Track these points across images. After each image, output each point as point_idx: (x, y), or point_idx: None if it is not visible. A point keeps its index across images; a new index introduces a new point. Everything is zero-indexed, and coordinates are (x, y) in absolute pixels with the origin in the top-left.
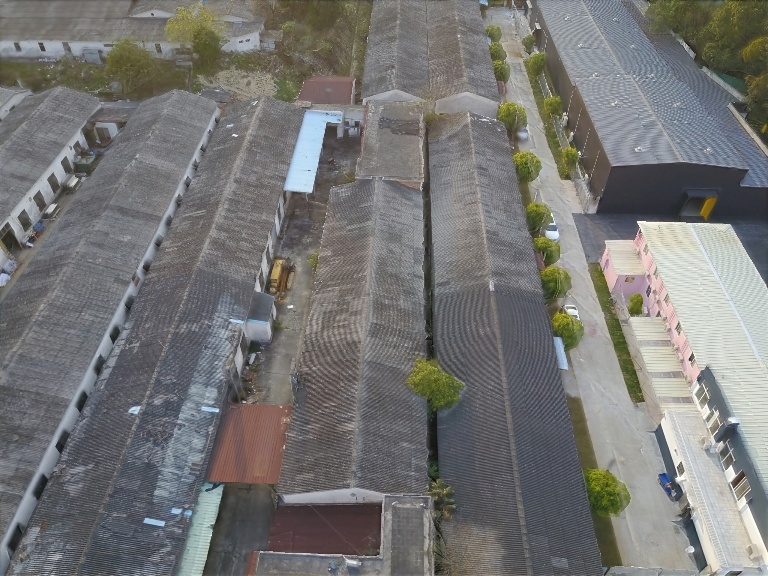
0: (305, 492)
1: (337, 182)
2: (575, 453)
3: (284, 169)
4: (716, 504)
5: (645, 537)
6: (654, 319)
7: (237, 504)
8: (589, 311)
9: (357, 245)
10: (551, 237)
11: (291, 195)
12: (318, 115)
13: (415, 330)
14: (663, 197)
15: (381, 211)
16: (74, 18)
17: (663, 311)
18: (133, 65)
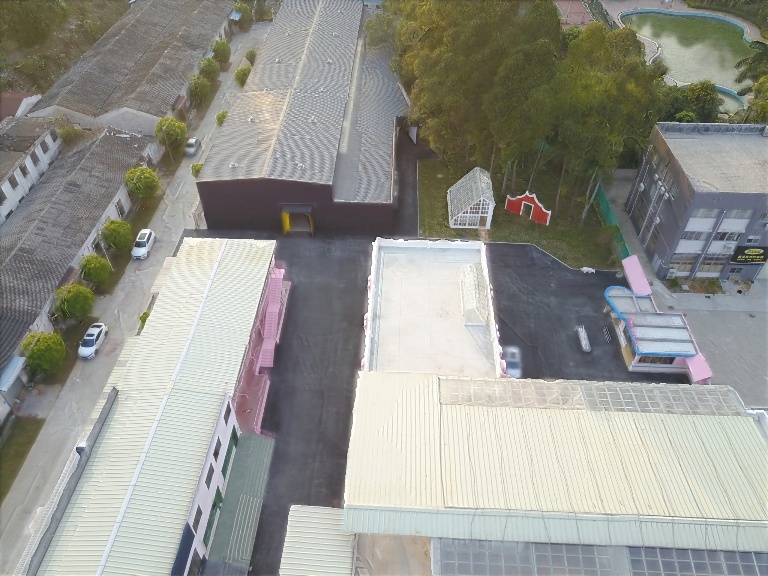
0: None
1: None
2: None
3: None
4: None
5: (1, 565)
6: None
7: None
8: (124, 329)
9: None
10: (136, 254)
11: None
12: None
13: None
14: (265, 212)
15: None
16: None
17: None
18: None
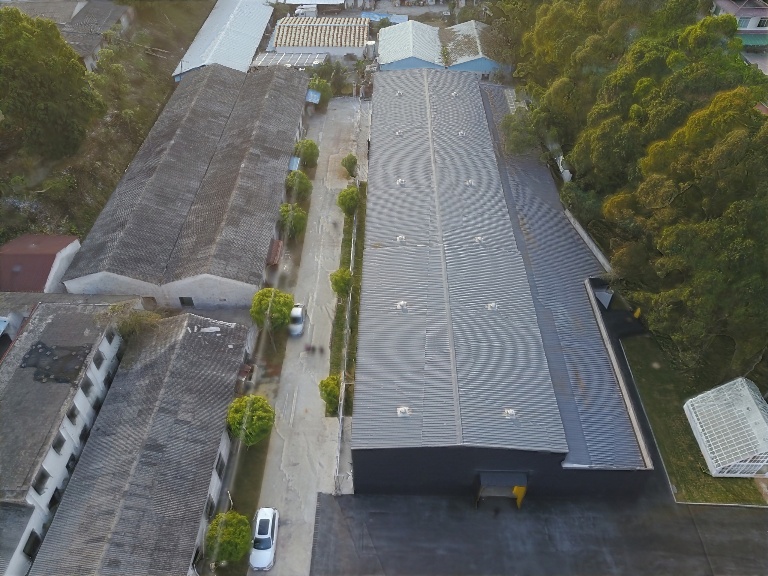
0: None
1: None
2: None
3: None
4: None
5: None
6: None
7: None
8: None
9: None
10: (257, 563)
11: None
12: None
13: None
14: (448, 477)
15: None
16: None
17: None
18: None
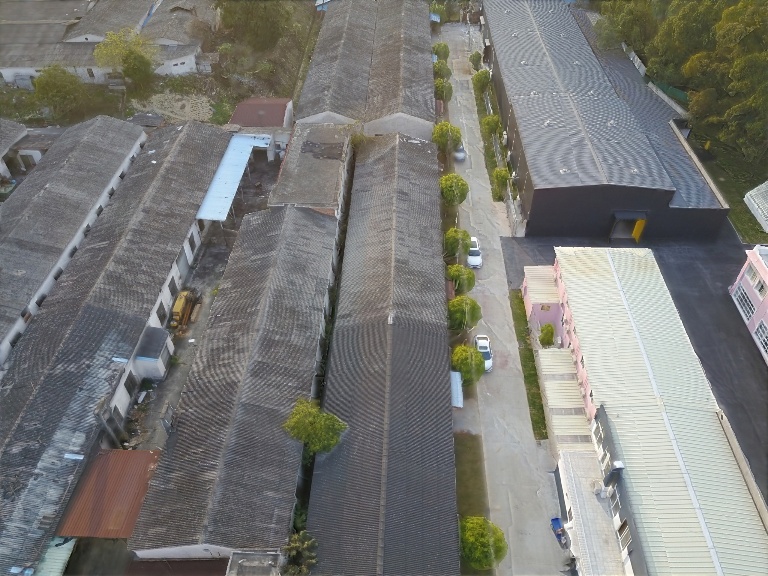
0: (154, 548)
1: (261, 207)
2: (453, 500)
3: (199, 196)
4: (599, 555)
5: None
6: (563, 351)
7: (100, 556)
8: (503, 341)
9: (257, 277)
10: (473, 263)
11: (212, 222)
12: (245, 139)
13: (303, 367)
14: (591, 219)
15: (287, 240)
16: (8, 44)
17: (572, 342)
18: (59, 91)
